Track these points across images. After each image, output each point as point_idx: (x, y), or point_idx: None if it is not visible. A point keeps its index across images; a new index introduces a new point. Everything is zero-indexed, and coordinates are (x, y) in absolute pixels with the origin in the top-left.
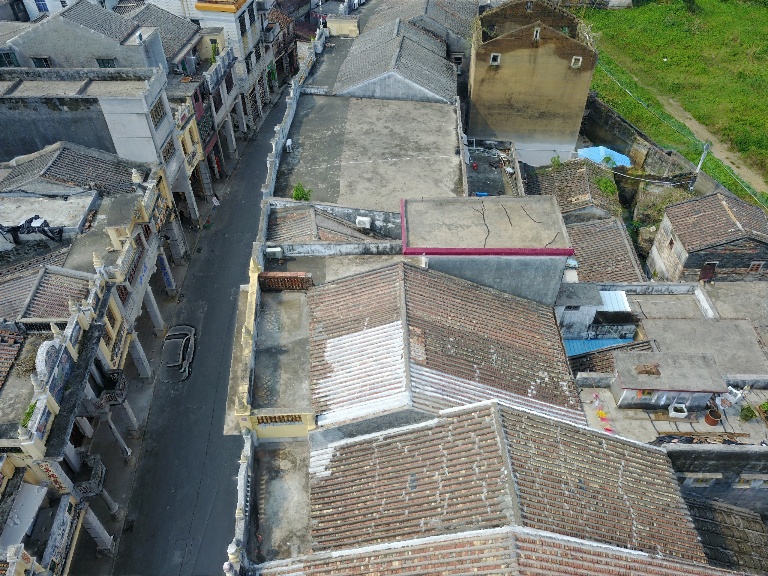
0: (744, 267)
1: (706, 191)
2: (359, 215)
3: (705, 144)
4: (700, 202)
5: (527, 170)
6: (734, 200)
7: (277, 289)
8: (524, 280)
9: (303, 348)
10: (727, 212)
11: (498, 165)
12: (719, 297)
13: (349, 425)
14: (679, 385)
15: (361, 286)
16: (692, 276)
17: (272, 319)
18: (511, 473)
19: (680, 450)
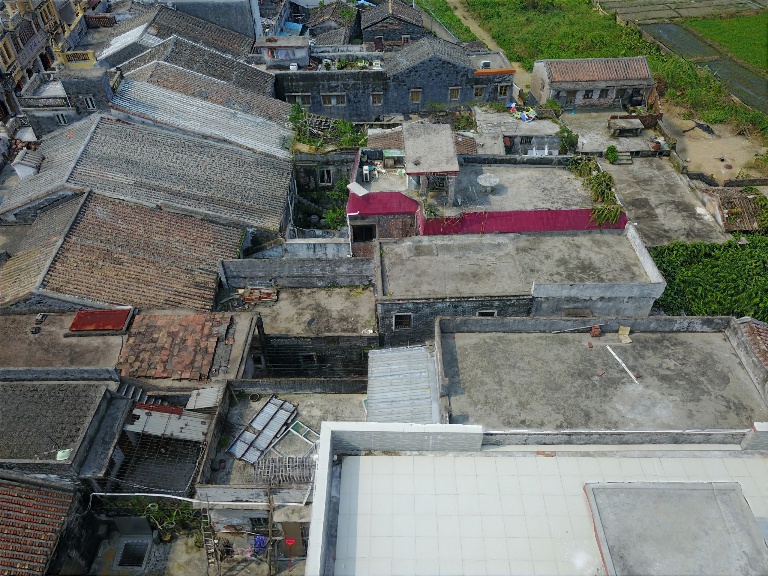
0: (399, 40)
1: (429, 26)
2: (158, 3)
3: (449, 6)
4: (380, 6)
5: (305, 11)
6: (401, 5)
7: (97, 26)
8: (232, 18)
9: (102, 44)
10: (389, 7)
11: (277, 2)
12: (383, 57)
13: (110, 57)
14: (284, 45)
15: (138, 18)
16: (371, 48)
17: (90, 36)
18: (169, 52)
19: (281, 73)
